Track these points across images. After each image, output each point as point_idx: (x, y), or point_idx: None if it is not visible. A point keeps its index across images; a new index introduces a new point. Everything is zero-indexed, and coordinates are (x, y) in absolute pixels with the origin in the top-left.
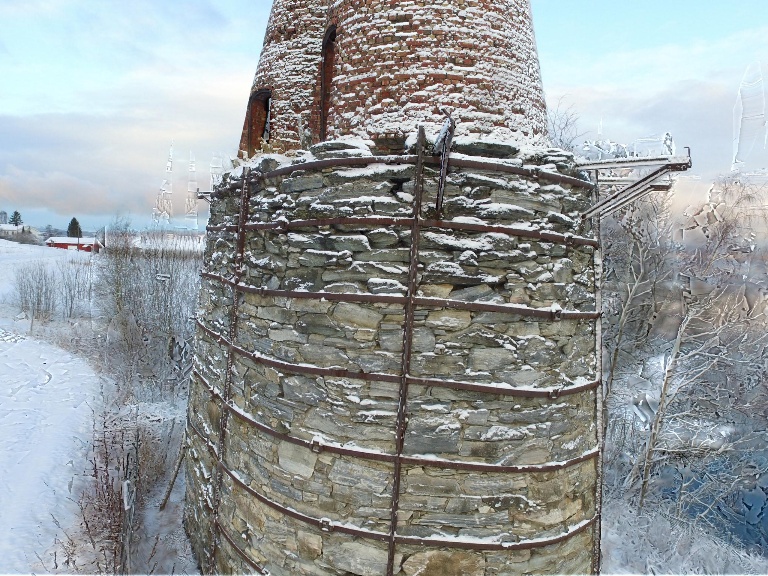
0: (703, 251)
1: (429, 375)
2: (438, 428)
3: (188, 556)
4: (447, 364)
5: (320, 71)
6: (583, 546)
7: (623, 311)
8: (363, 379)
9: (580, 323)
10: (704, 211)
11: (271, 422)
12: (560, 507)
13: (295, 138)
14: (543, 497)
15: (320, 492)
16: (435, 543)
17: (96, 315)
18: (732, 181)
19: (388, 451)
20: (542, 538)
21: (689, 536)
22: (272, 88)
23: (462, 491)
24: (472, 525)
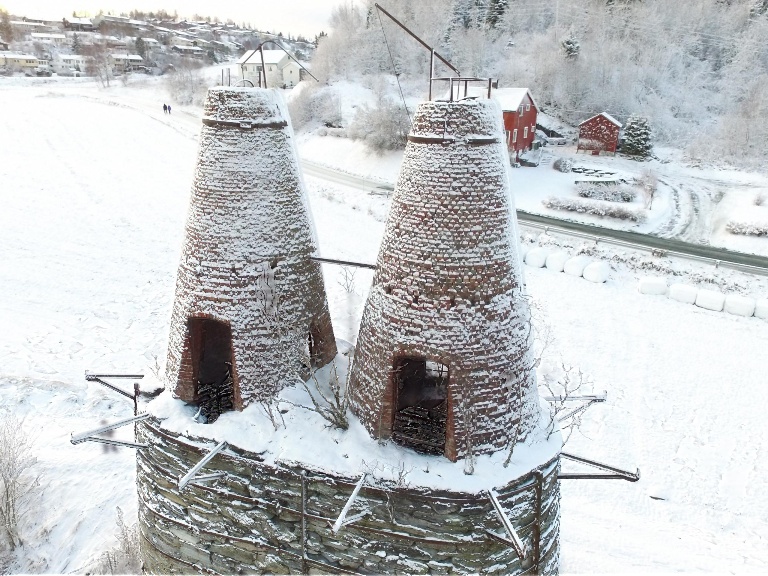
0: None
1: None
2: None
3: None
4: None
5: None
6: None
7: None
8: None
9: None
10: None
11: None
12: None
13: None
14: None
15: None
16: None
17: None
18: None
19: None
20: None
21: None
22: None
23: None
24: None
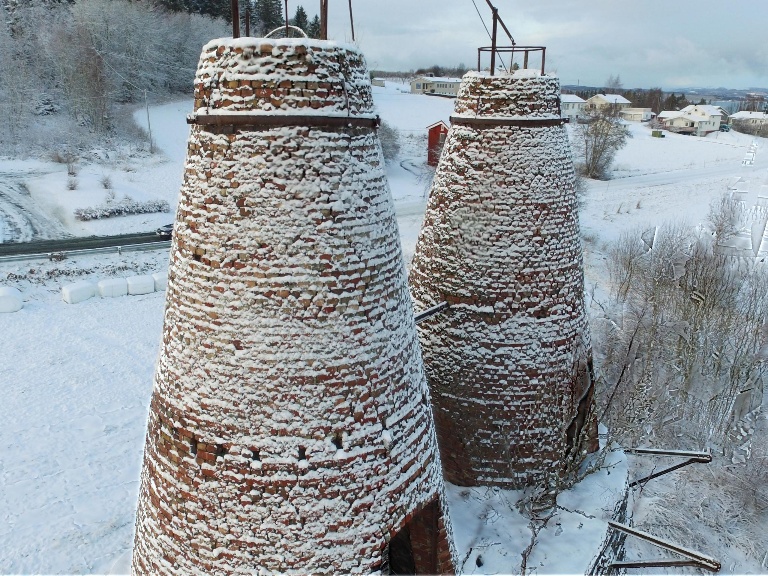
0: None
1: None
2: None
3: None
4: None
5: None
6: None
7: None
8: None
9: None
10: None
11: None
12: None
13: None
14: None
15: None
16: None
17: (627, 317)
18: None
19: None
20: None
21: None
22: None
23: None
24: None
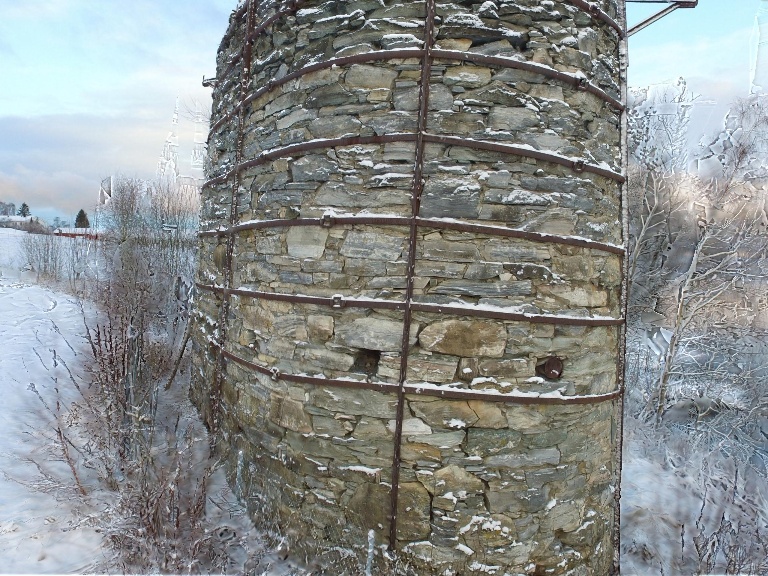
0: (719, 179)
1: (447, 134)
2: (456, 189)
3: (194, 416)
4: (466, 122)
5: None
6: (608, 349)
7: (637, 243)
8: (377, 143)
9: (605, 106)
10: (720, 139)
11: (279, 213)
12: (585, 289)
13: None
14: (567, 271)
15: (331, 269)
16: (453, 310)
17: (102, 265)
18: (749, 105)
19: (403, 215)
20: (566, 315)
21: (708, 444)
22: None
23: (482, 258)
24: (493, 294)
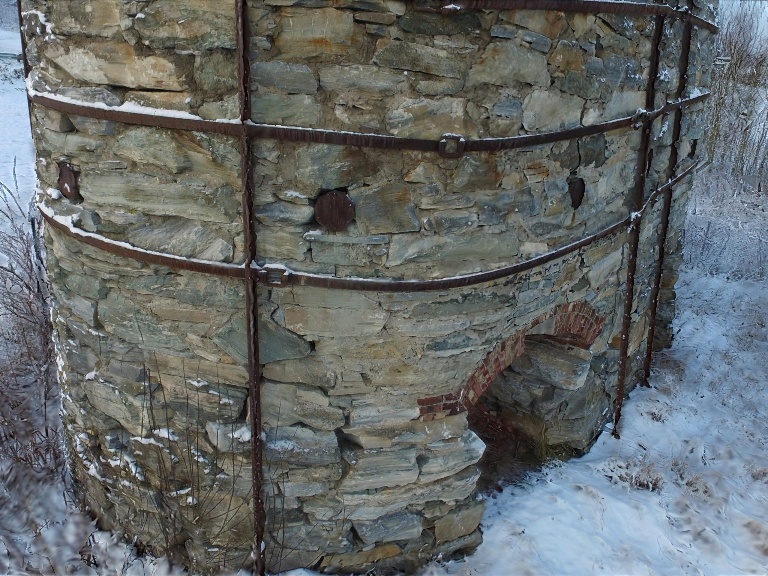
0: None
1: None
2: None
3: None
4: None
5: None
6: (216, 180)
7: None
8: None
9: None
10: None
11: None
12: (94, 50)
13: None
14: None
15: None
16: None
17: None
18: None
19: None
20: (65, 97)
21: None
22: None
23: None
24: None
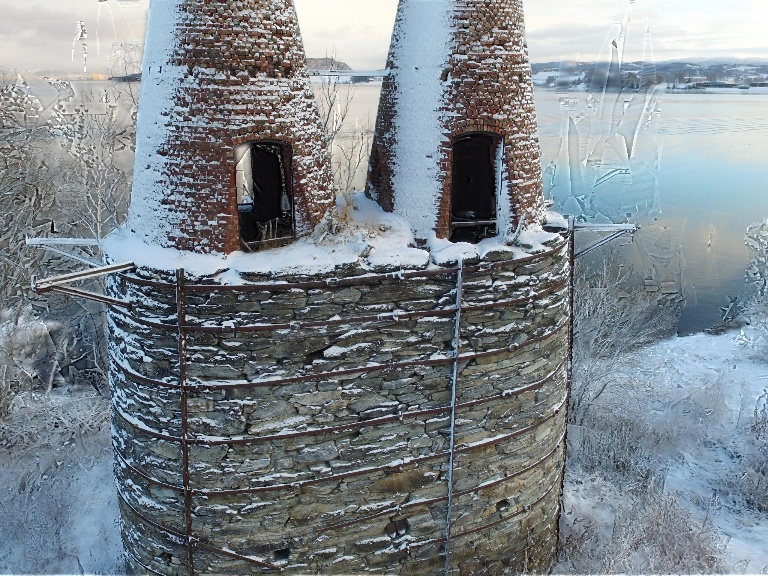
0: None
1: None
2: None
3: None
4: None
5: (451, 158)
6: None
7: None
8: None
9: None
10: (128, 132)
11: None
12: None
13: (325, 198)
14: None
15: None
16: None
17: None
18: None
19: None
20: None
21: None
22: (292, 141)
23: None
24: None
